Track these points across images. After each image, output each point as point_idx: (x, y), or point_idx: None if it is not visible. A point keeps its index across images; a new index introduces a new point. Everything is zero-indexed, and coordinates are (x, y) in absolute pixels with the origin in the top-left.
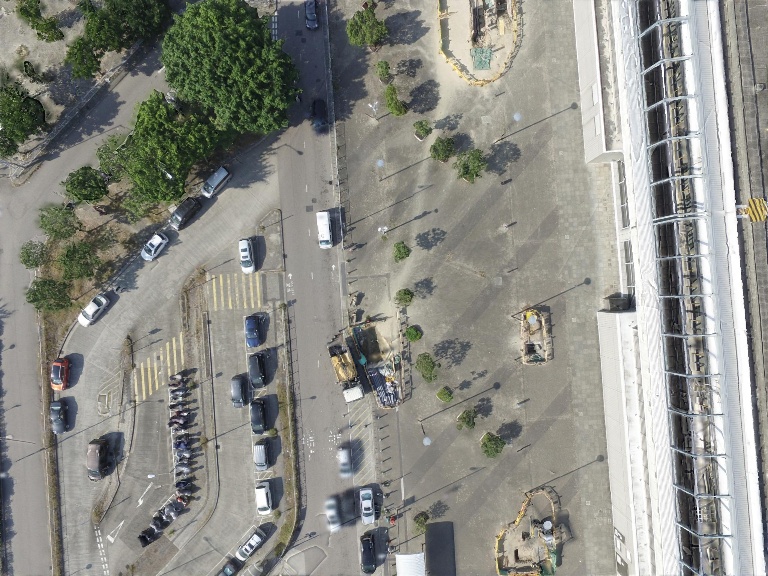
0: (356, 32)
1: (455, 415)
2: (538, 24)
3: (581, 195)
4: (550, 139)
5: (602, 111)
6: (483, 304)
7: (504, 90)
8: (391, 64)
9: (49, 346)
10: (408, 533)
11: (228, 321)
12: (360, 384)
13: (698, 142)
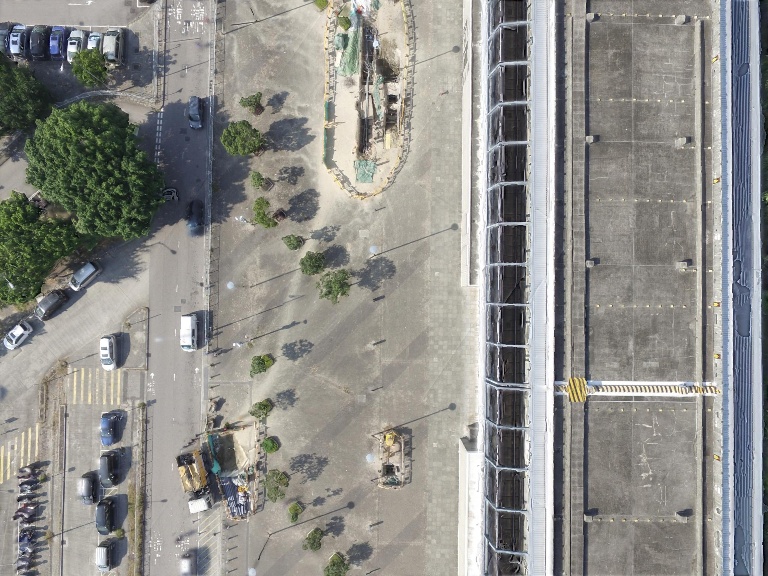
0: (229, 143)
1: (306, 531)
2: (425, 141)
3: (454, 318)
4: (427, 258)
5: (469, 244)
6: (344, 421)
7: (385, 205)
8: (273, 170)
9: None
10: None
11: (86, 416)
12: (208, 494)
13: None
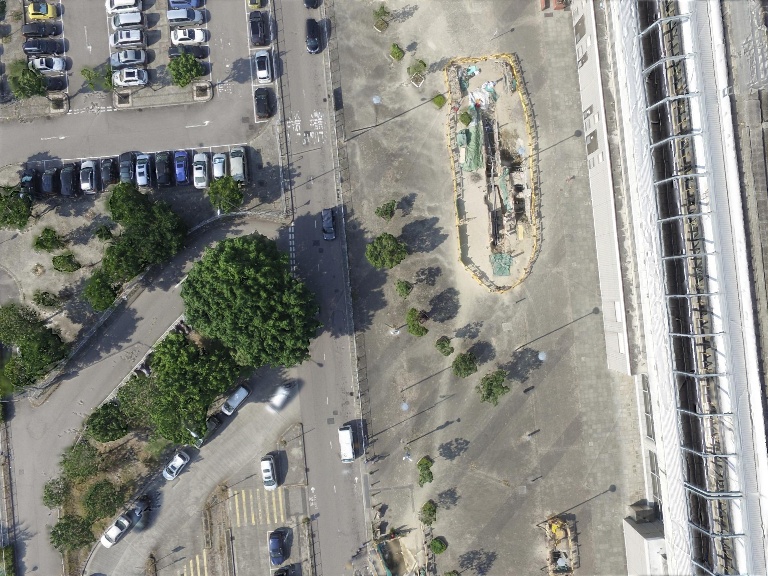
0: (376, 258)
1: None
2: (557, 228)
3: (604, 401)
4: (572, 345)
5: (626, 335)
6: (508, 513)
7: (524, 296)
8: (410, 273)
9: (72, 568)
10: None
11: (251, 537)
12: None
13: (729, 405)
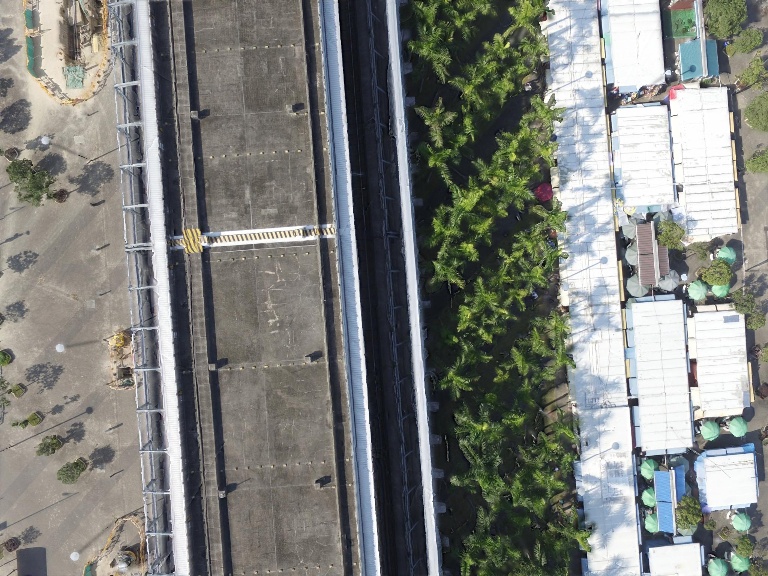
0: None
1: None
2: None
3: None
4: None
5: None
6: (75, 328)
7: (97, 109)
8: None
9: None
10: None
11: None
12: None
13: None
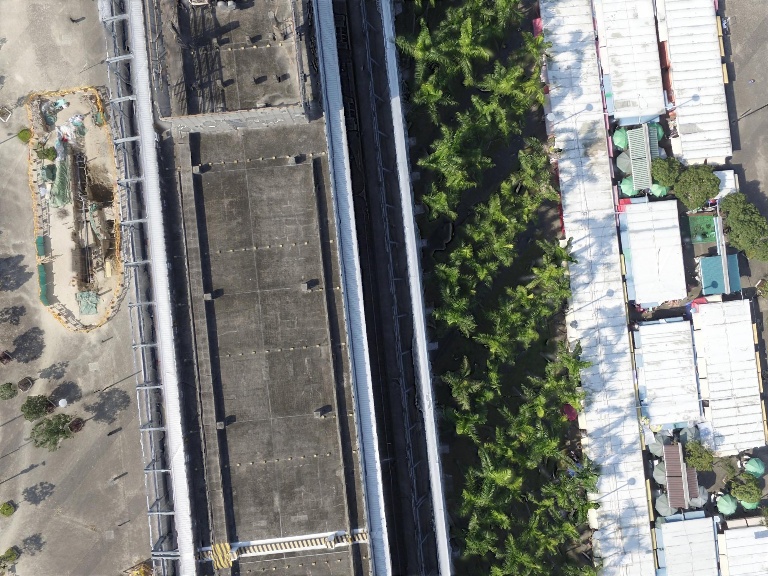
0: None
1: None
2: None
3: None
4: None
5: None
6: (94, 559)
7: (112, 335)
8: None
9: None
10: None
11: None
12: None
13: None
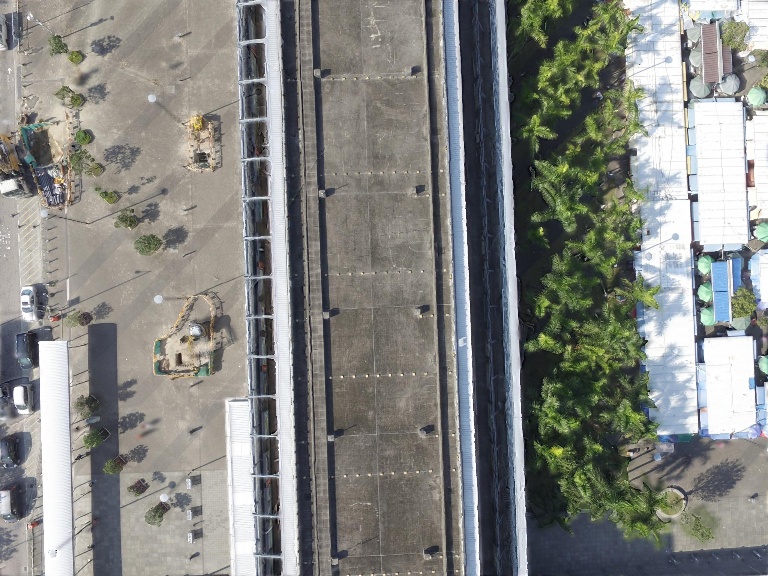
0: None
1: None
2: None
3: None
4: None
5: None
6: (155, 111)
7: None
8: None
9: None
10: (72, 333)
11: None
12: (21, 180)
13: None
